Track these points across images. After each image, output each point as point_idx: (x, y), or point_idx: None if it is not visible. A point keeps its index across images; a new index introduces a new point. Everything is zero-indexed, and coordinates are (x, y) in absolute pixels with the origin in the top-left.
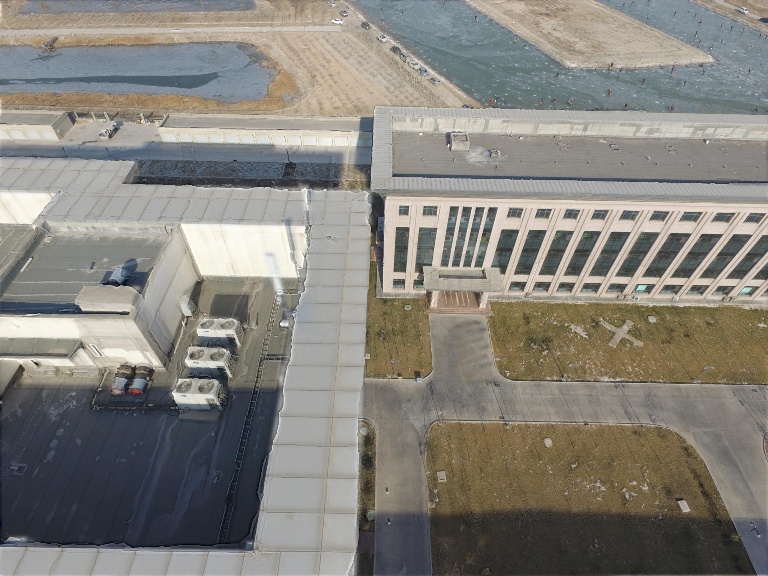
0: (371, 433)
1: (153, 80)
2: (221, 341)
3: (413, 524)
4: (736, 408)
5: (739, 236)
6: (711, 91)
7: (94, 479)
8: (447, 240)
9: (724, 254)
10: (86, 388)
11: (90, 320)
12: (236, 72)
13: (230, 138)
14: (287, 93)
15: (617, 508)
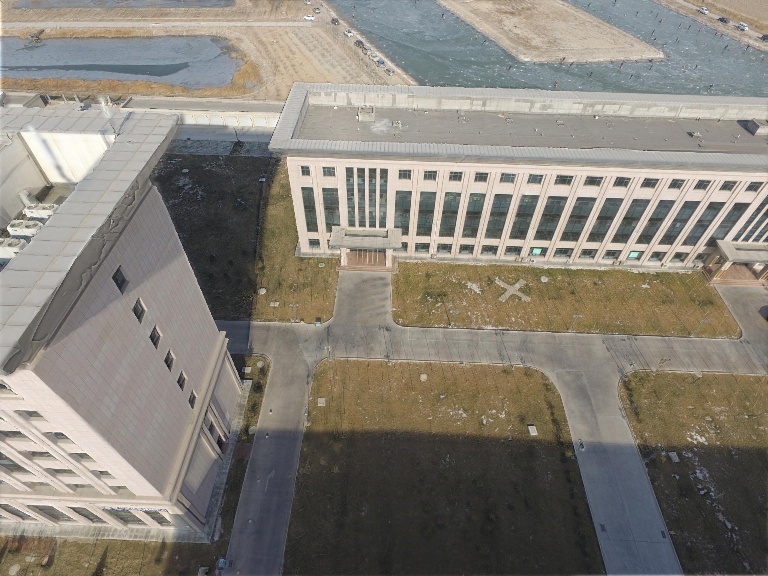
0: (266, 366)
1: (127, 68)
2: (43, 220)
3: (288, 438)
4: (602, 353)
5: (613, 200)
6: (654, 84)
7: None
8: (350, 201)
9: (604, 218)
10: None
11: None
12: (206, 62)
13: (186, 119)
14: (250, 81)
15: (473, 431)
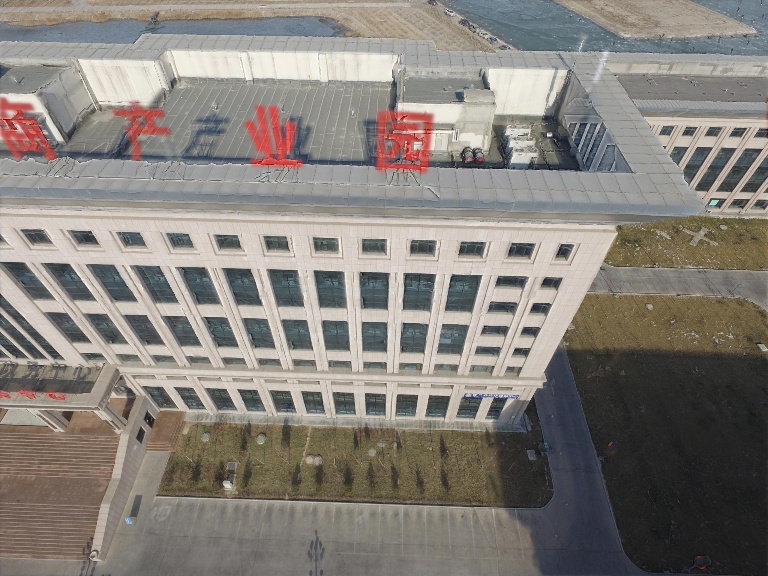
0: None
1: None
2: None
3: (554, 354)
4: None
5: None
6: None
7: None
8: None
9: None
10: (445, 161)
11: (473, 106)
12: None
13: None
14: None
15: (710, 348)
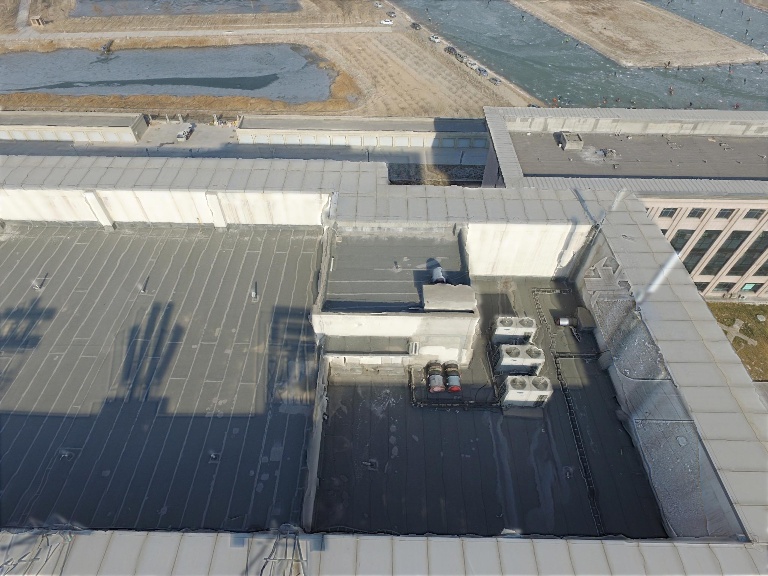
0: None
1: (215, 82)
2: None
3: None
4: None
5: None
6: None
7: (446, 474)
8: None
9: None
10: (397, 385)
11: (438, 318)
12: (295, 73)
13: (307, 139)
14: (350, 94)
15: None
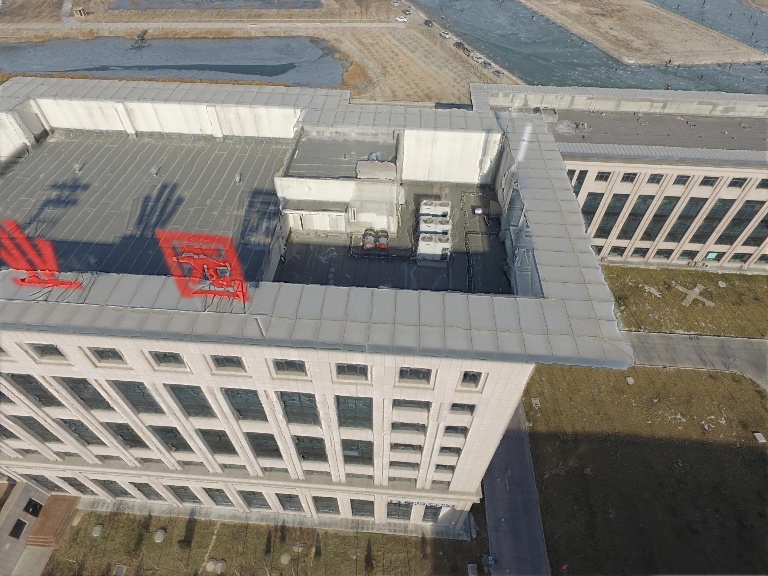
0: None
1: (237, 69)
2: None
3: (514, 438)
4: None
5: None
6: None
7: None
8: None
9: None
10: (340, 245)
11: (367, 183)
12: (311, 63)
13: None
14: (361, 82)
15: (697, 436)
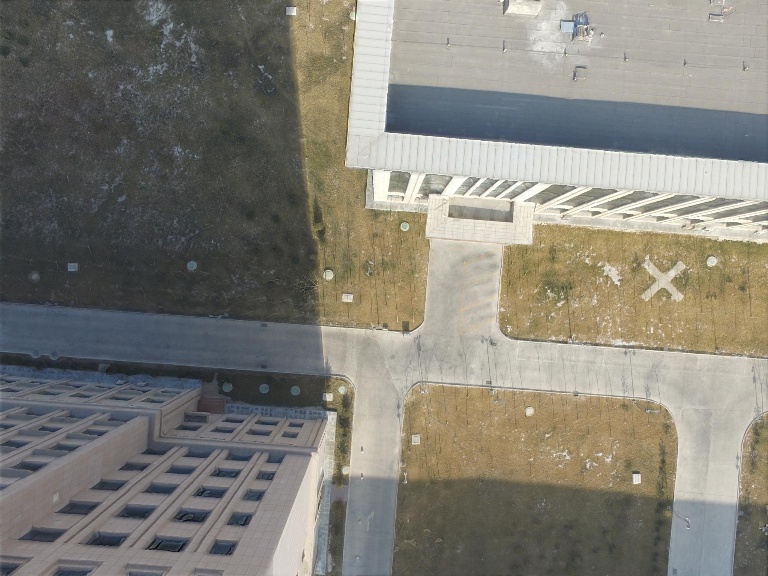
0: (350, 392)
1: None
2: None
3: (384, 479)
4: (745, 386)
5: None
6: None
7: None
8: (467, 180)
9: None
10: None
11: None
12: None
13: None
14: None
15: (574, 475)
